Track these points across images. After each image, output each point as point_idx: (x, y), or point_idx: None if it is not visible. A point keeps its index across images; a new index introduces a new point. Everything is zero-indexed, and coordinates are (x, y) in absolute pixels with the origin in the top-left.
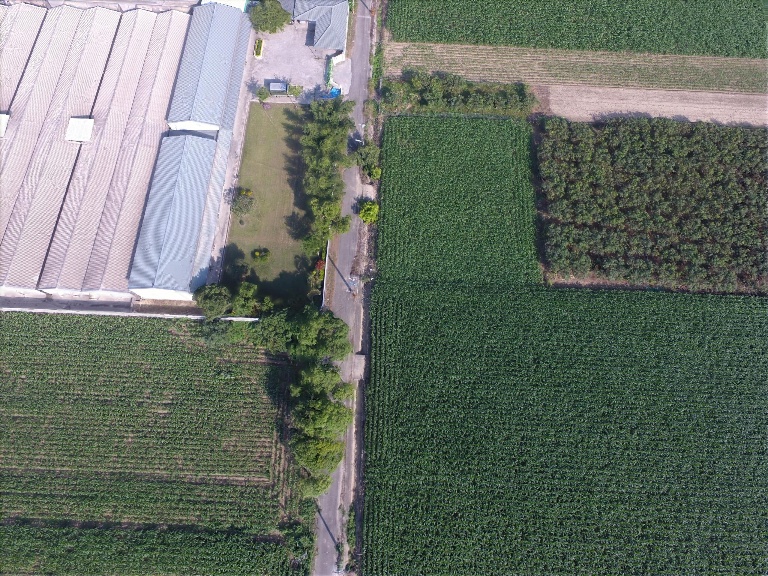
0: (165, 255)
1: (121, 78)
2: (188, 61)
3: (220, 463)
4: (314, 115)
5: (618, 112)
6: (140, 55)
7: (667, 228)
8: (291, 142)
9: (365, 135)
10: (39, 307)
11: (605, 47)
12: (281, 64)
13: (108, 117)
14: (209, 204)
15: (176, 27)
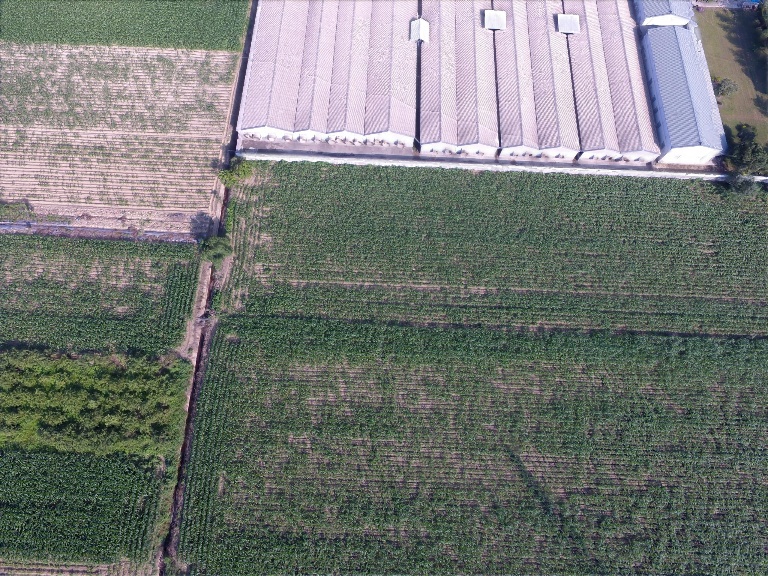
0: (699, 120)
1: None
2: None
3: None
4: (766, 12)
5: None
6: None
7: None
8: (732, 39)
9: None
10: (572, 170)
11: None
12: None
13: (586, 14)
14: None
15: None
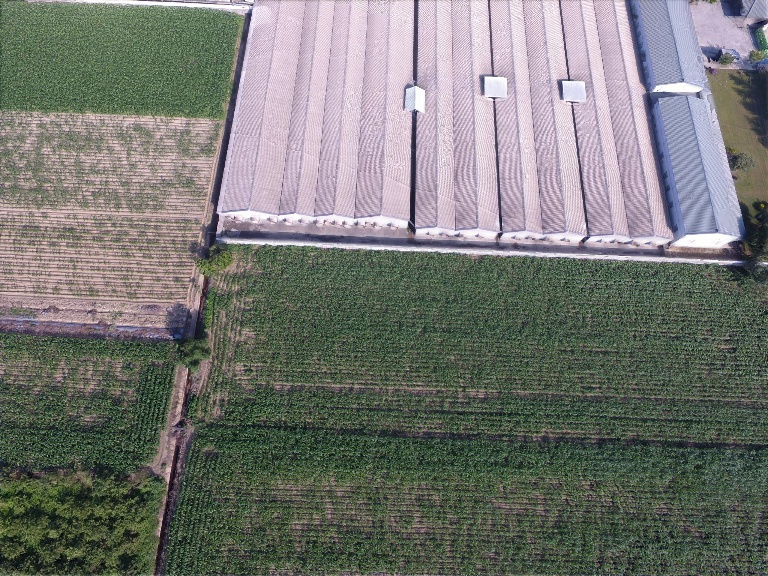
0: (715, 204)
1: (588, 44)
2: (653, 28)
3: None
4: None
5: None
6: (593, 23)
7: None
8: (747, 105)
9: None
10: None
11: None
12: (710, 33)
13: (593, 80)
14: None
15: None
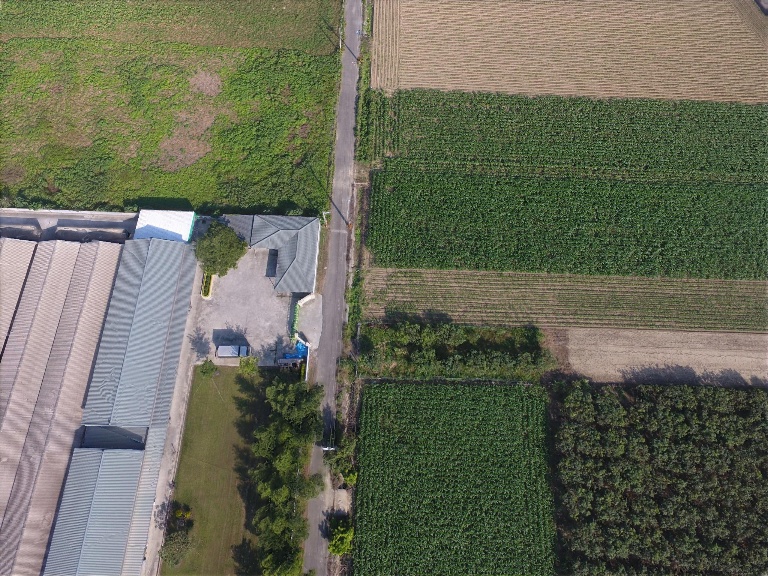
0: None
1: (28, 347)
2: None
3: None
4: (271, 404)
5: (653, 366)
6: (55, 308)
7: (725, 566)
8: (244, 426)
9: (338, 413)
10: None
11: (635, 272)
12: (235, 306)
13: (7, 410)
14: (130, 552)
15: (102, 266)
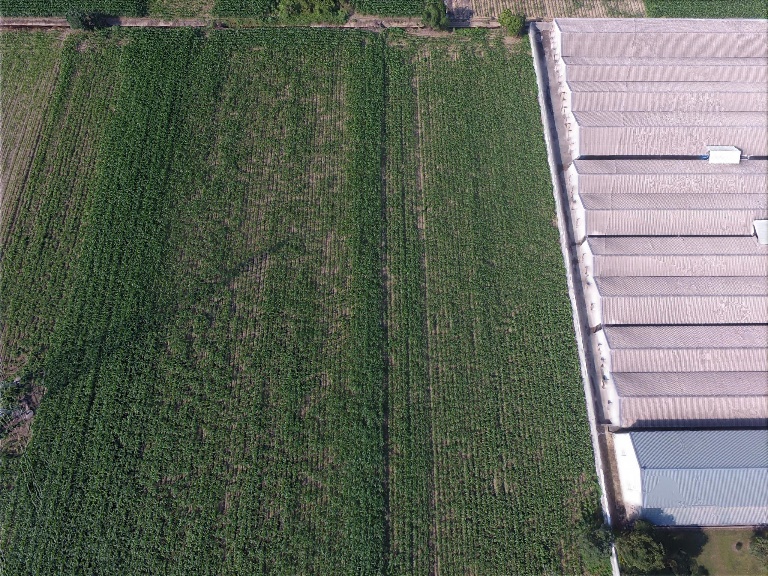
0: (683, 474)
1: None
2: None
3: (451, 567)
4: None
5: None
6: None
7: None
8: None
9: None
10: None
11: None
12: None
13: None
14: (760, 510)
15: None
